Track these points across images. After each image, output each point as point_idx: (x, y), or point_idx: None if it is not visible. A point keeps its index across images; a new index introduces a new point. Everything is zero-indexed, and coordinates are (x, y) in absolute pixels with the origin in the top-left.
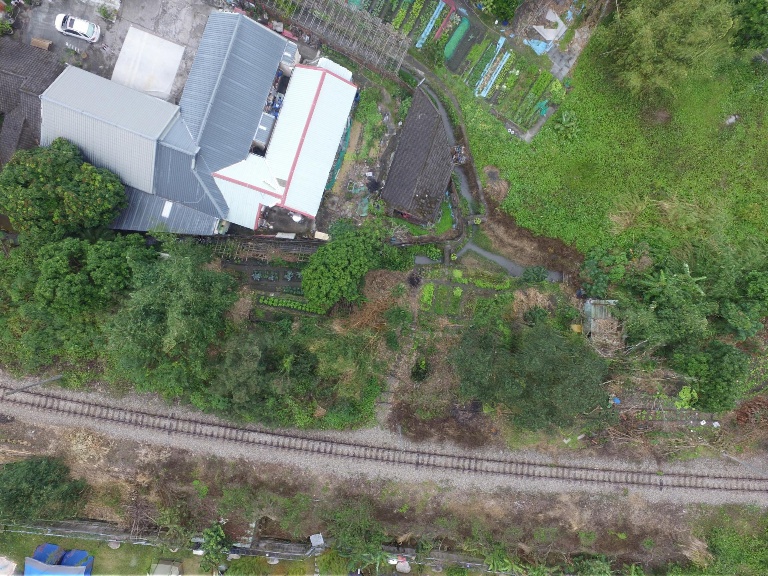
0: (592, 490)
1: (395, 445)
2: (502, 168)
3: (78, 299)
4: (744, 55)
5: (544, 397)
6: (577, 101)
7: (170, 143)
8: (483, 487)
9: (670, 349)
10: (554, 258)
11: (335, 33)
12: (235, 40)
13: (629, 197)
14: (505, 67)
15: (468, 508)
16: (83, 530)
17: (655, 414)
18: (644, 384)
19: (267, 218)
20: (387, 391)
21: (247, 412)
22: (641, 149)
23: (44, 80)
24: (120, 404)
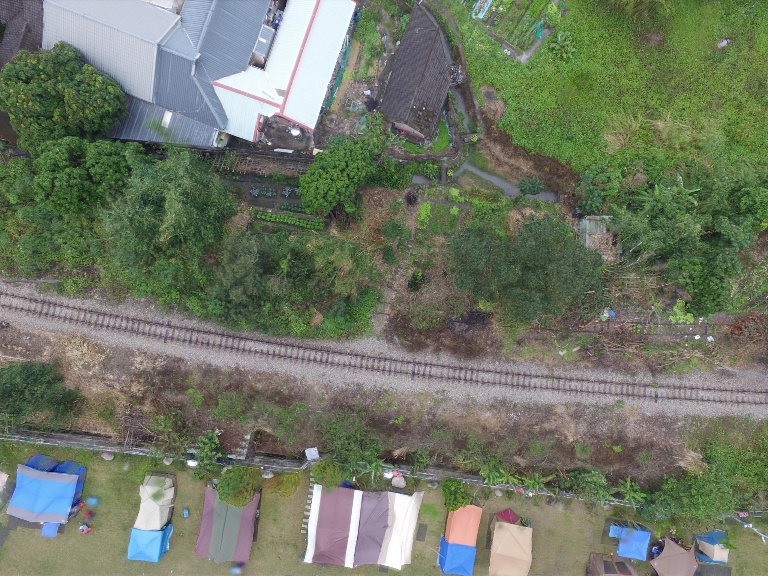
0: (587, 402)
1: (391, 355)
2: (498, 87)
3: (76, 192)
4: None
5: (539, 281)
6: (572, 22)
7: (171, 48)
8: (479, 398)
9: (664, 260)
10: (550, 178)
11: None
12: None
13: (623, 117)
14: None
15: (464, 420)
16: (77, 441)
17: (650, 328)
18: (639, 298)
19: (266, 134)
20: (384, 302)
21: (244, 318)
22: (635, 70)
23: None
24: (116, 311)
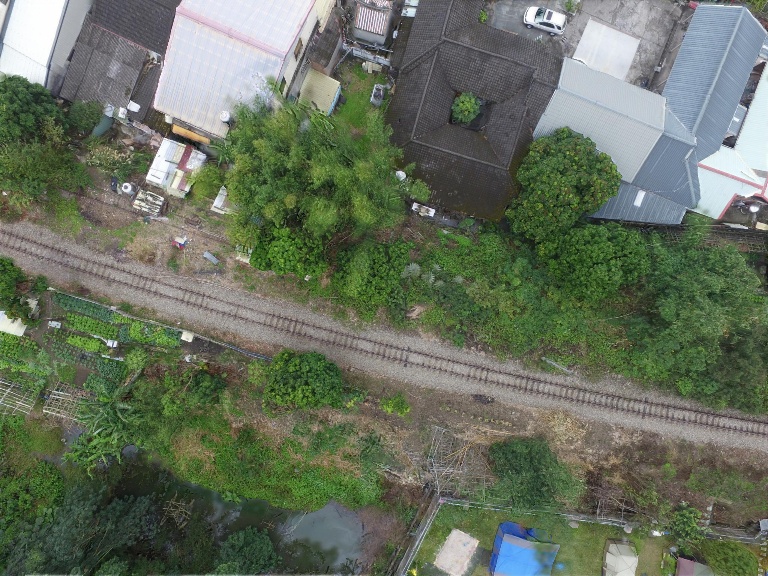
0: None
1: None
2: None
3: None
4: None
5: None
6: None
7: (671, 133)
8: None
9: None
10: None
11: None
12: (736, 33)
13: None
14: None
15: None
16: (543, 509)
17: None
18: None
19: None
20: None
21: None
22: None
23: (551, 71)
24: (596, 387)
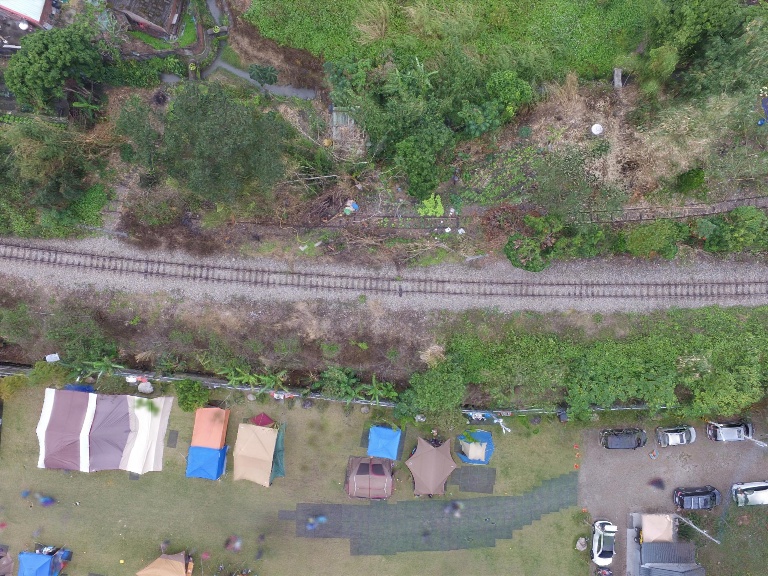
0: (329, 297)
1: (123, 254)
2: None
3: None
4: None
5: (200, 147)
6: None
7: None
8: (217, 297)
9: None
10: (304, 72)
11: None
12: None
13: (376, 4)
14: None
15: (202, 319)
16: None
17: (398, 222)
18: (386, 191)
19: (0, 32)
20: (115, 200)
21: None
22: None
23: None
24: None
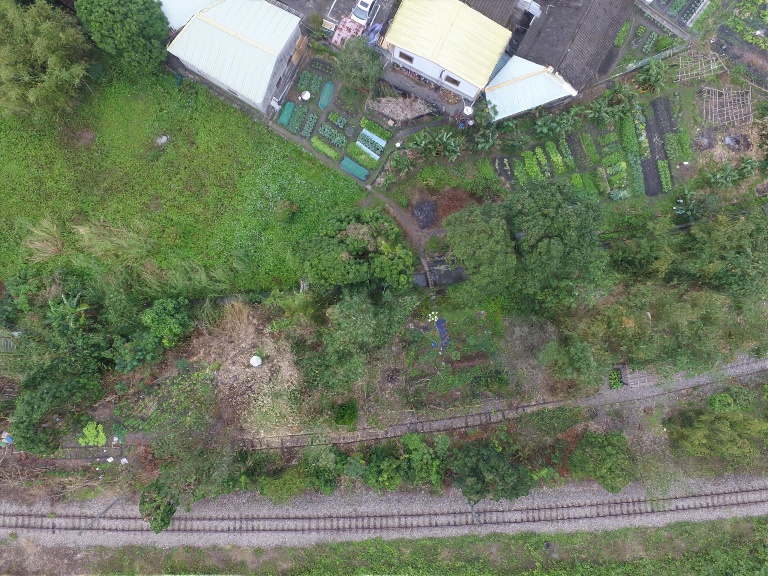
0: None
1: None
2: None
3: None
4: (169, 73)
5: None
6: None
7: None
8: None
9: None
10: None
11: None
12: None
13: (48, 223)
14: None
15: None
16: None
17: (59, 452)
18: None
19: None
20: None
21: None
22: (62, 172)
23: None
24: None
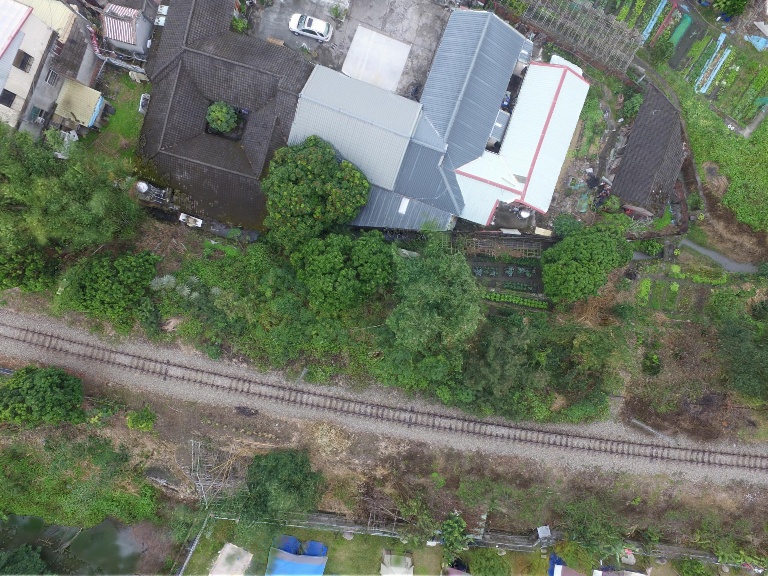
0: None
1: (629, 438)
2: (723, 164)
3: (351, 294)
4: None
5: None
6: None
7: (421, 140)
8: (715, 480)
9: None
10: None
11: (567, 31)
12: (484, 38)
13: None
14: (725, 63)
15: (700, 501)
16: (317, 521)
17: None
18: None
19: None
20: None
21: (490, 405)
22: None
23: (298, 79)
24: (361, 397)
